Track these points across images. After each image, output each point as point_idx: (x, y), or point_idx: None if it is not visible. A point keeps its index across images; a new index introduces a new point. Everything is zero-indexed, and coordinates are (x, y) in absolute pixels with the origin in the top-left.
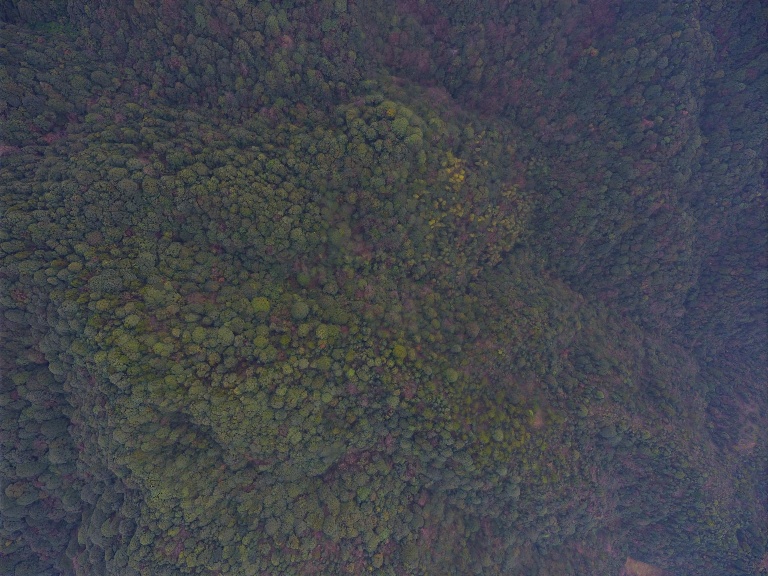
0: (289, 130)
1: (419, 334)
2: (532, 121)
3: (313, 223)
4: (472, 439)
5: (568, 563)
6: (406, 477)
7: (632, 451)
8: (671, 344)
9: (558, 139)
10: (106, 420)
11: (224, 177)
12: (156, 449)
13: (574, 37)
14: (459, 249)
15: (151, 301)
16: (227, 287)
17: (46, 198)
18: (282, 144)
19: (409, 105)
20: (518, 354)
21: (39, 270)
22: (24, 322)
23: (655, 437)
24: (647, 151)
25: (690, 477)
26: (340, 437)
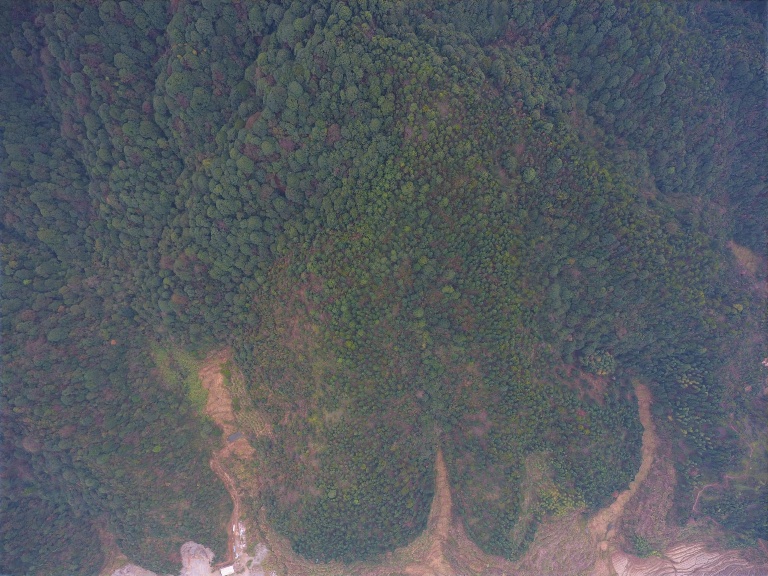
0: None
1: None
2: None
3: None
4: (634, 8)
5: None
6: (557, 67)
7: (759, 100)
8: None
9: None
10: None
11: None
12: None
13: None
14: None
15: None
16: None
17: None
18: None
19: None
20: None
21: None
22: None
23: None
24: None
25: None
26: (506, 1)
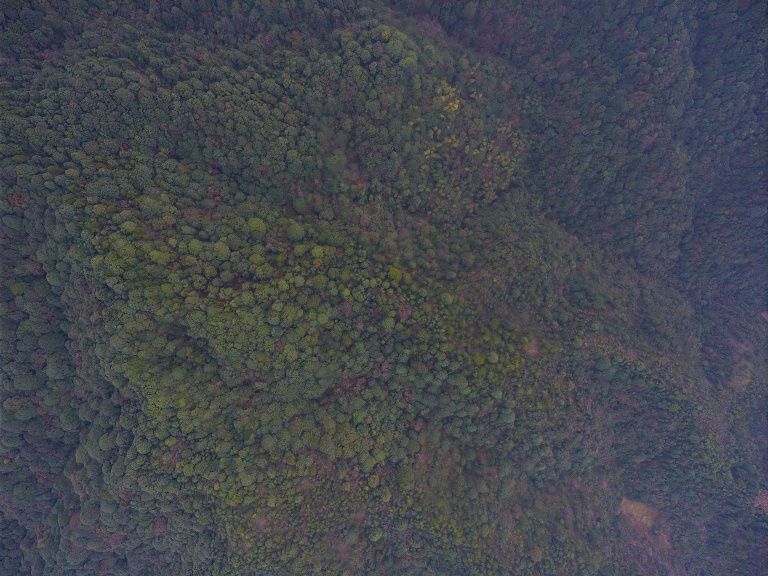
0: (285, 55)
1: (414, 261)
2: (527, 60)
3: (309, 147)
4: (467, 360)
5: (564, 496)
6: (402, 403)
7: (627, 385)
8: (666, 288)
9: (552, 77)
10: (103, 328)
11: (220, 92)
12: (153, 359)
13: None
14: (454, 184)
15: (147, 210)
16: (223, 205)
17: (43, 104)
18: (278, 67)
19: (404, 31)
20: (513, 285)
21: (36, 174)
22: (22, 229)
23: (650, 369)
24: (640, 83)
25: (685, 410)
26: (336, 360)
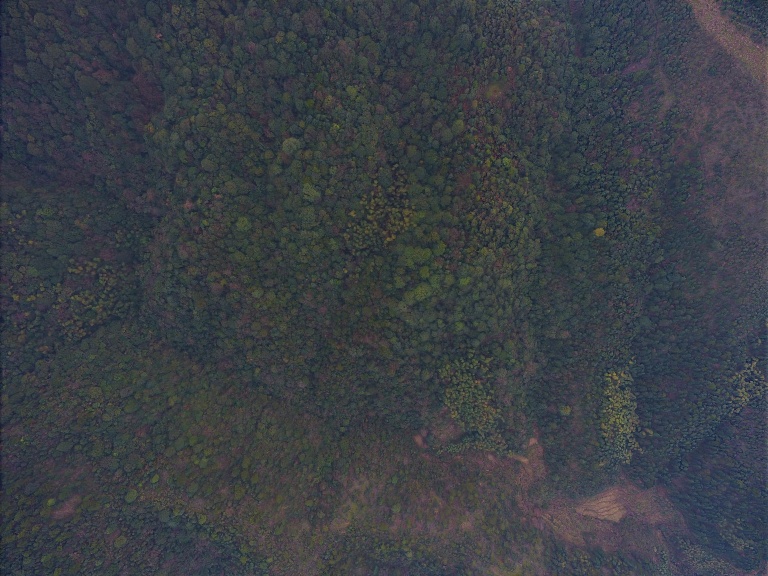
0: None
1: None
2: (121, 192)
3: None
4: None
5: None
6: None
7: None
8: (303, 414)
9: (145, 212)
10: None
11: None
12: None
13: (131, 113)
14: (20, 327)
15: None
16: None
17: None
18: None
19: None
20: (61, 438)
21: None
22: None
23: (213, 522)
24: (196, 232)
25: (254, 562)
26: None
